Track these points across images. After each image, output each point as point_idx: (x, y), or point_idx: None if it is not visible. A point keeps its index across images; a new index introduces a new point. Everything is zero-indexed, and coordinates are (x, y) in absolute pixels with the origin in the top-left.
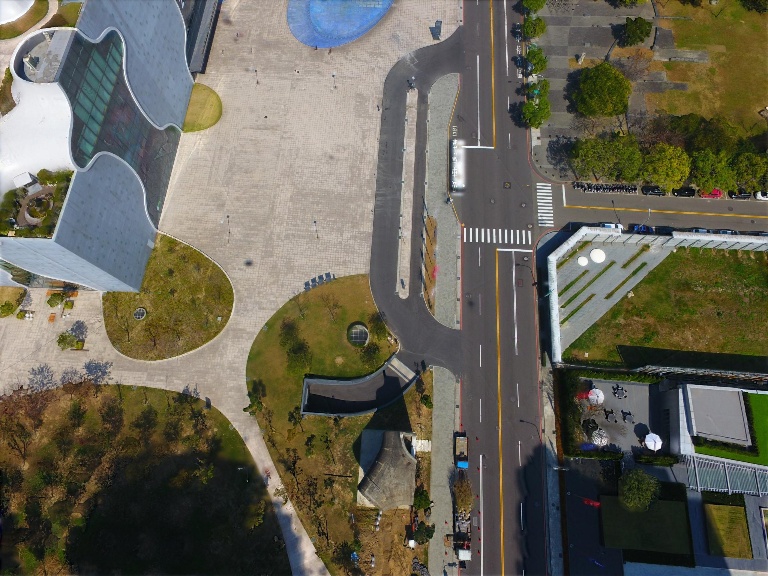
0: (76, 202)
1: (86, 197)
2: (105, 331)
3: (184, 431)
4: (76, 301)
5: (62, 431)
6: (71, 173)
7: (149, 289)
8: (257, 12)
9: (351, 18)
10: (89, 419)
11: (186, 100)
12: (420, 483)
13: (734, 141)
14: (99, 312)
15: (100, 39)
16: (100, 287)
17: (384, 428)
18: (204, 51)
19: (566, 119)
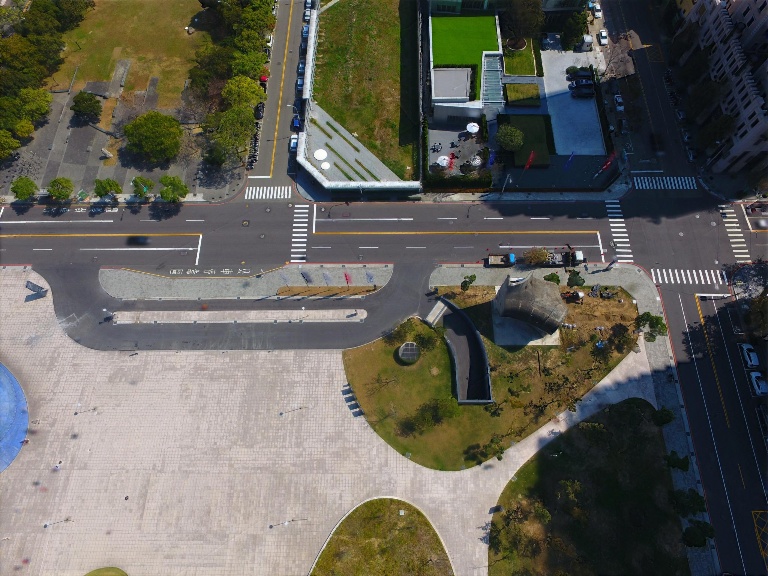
0: None
1: None
2: None
3: (527, 533)
4: None
5: None
6: None
7: None
8: None
9: None
10: None
11: None
12: None
13: None
14: None
15: None
16: None
17: (491, 326)
18: None
19: (176, 171)
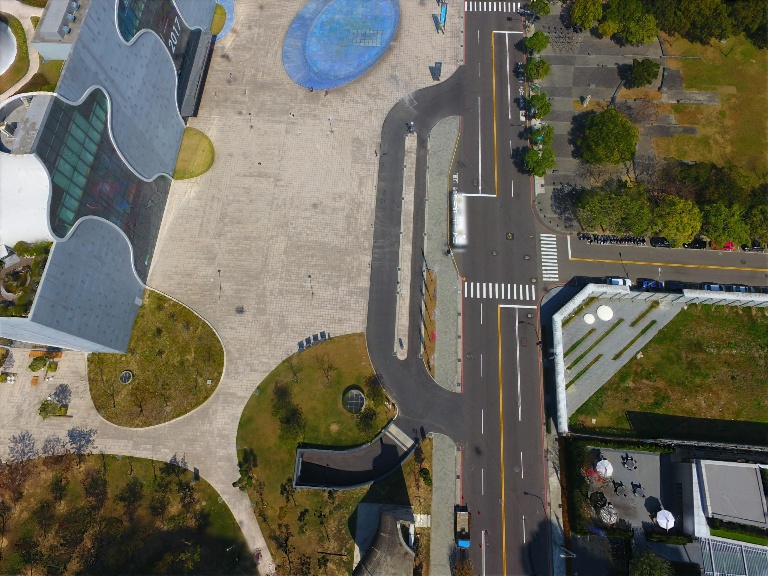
0: (55, 274)
1: (66, 267)
2: (90, 395)
3: (171, 505)
4: (60, 362)
5: (43, 505)
6: (50, 244)
7: (136, 350)
8: (251, 51)
9: (348, 57)
10: (71, 492)
11: (177, 146)
12: (419, 562)
13: (747, 192)
14: (84, 375)
15: (82, 100)
16: (85, 349)
17: (381, 501)
18: (196, 95)
19: (571, 165)
